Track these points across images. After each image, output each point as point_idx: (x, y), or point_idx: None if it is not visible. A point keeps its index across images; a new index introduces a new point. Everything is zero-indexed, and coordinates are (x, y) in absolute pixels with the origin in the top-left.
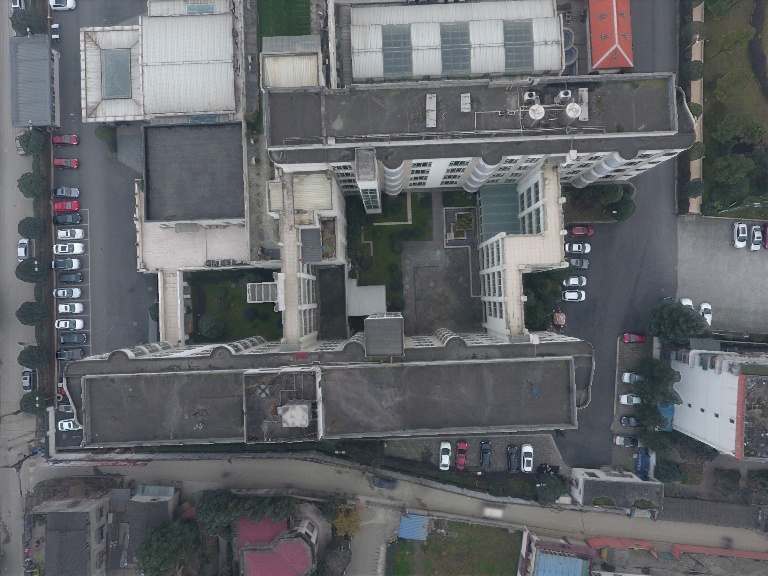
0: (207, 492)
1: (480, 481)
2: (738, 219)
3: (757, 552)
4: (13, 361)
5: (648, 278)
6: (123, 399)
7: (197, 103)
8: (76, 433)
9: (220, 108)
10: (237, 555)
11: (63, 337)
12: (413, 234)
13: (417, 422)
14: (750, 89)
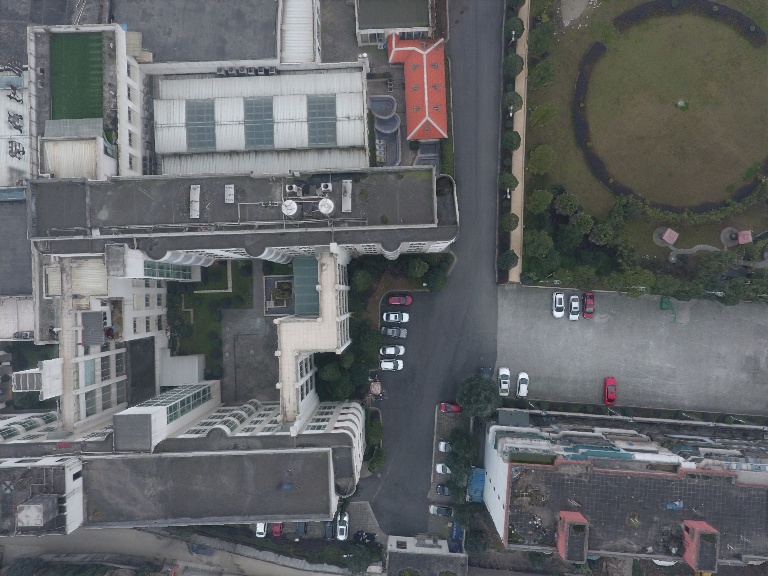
0: (17, 561)
1: (297, 548)
2: (558, 288)
3: None
4: None
5: (467, 347)
6: None
7: None
8: None
9: (23, 183)
10: None
11: None
12: (232, 302)
13: (179, 511)
14: (573, 158)
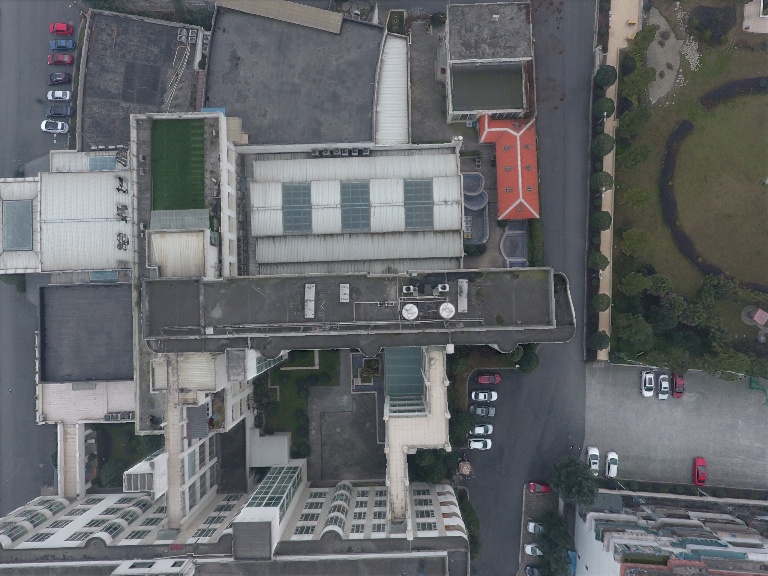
0: None
1: None
2: (646, 367)
3: None
4: None
5: (555, 425)
6: None
7: (95, 261)
8: None
9: (118, 266)
10: None
11: None
12: (319, 380)
13: None
14: (661, 235)
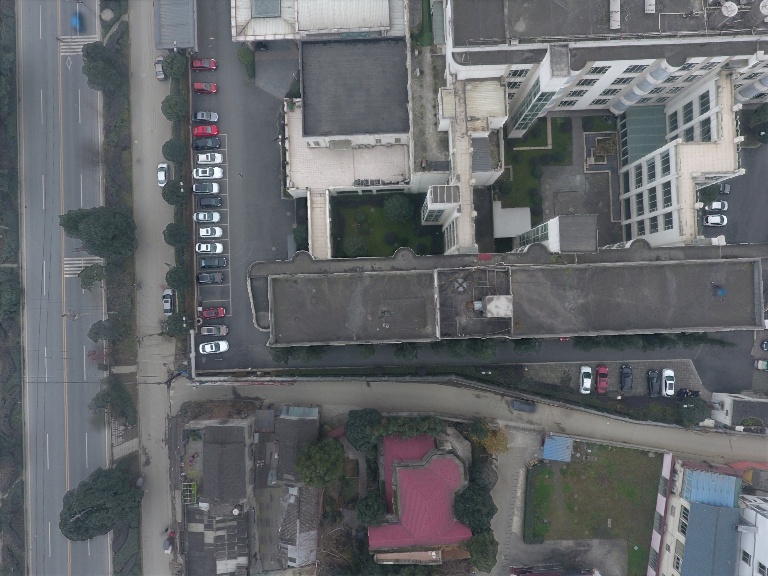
0: (355, 411)
1: (620, 405)
2: None
3: None
4: (152, 285)
5: None
6: (306, 300)
7: (351, 19)
8: (216, 356)
9: (374, 24)
10: (384, 474)
11: (204, 260)
12: (554, 158)
13: (600, 324)
14: None
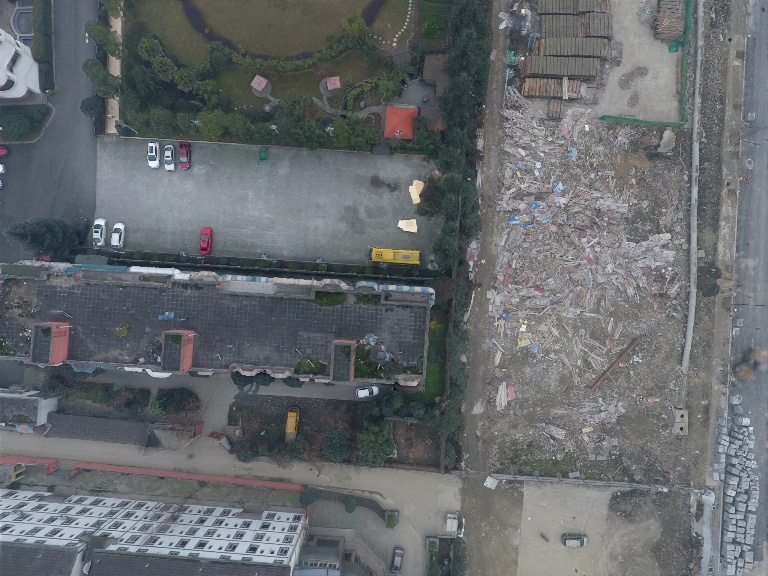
0: None
1: None
2: (156, 139)
3: (163, 470)
4: None
5: (65, 199)
6: None
7: None
8: None
9: None
10: None
11: None
12: None
13: None
14: (172, 9)
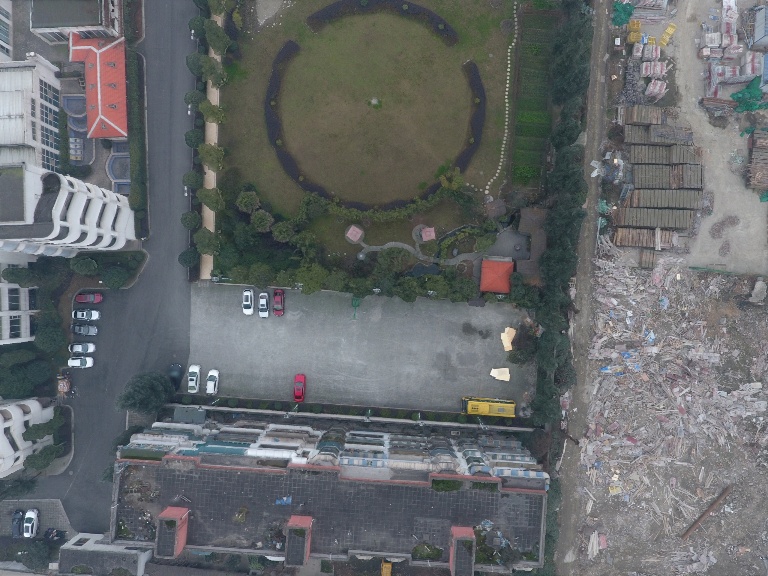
0: None
1: None
2: (250, 286)
3: None
4: None
5: (159, 344)
6: None
7: None
8: None
9: None
10: None
11: None
12: None
13: None
14: (266, 155)
